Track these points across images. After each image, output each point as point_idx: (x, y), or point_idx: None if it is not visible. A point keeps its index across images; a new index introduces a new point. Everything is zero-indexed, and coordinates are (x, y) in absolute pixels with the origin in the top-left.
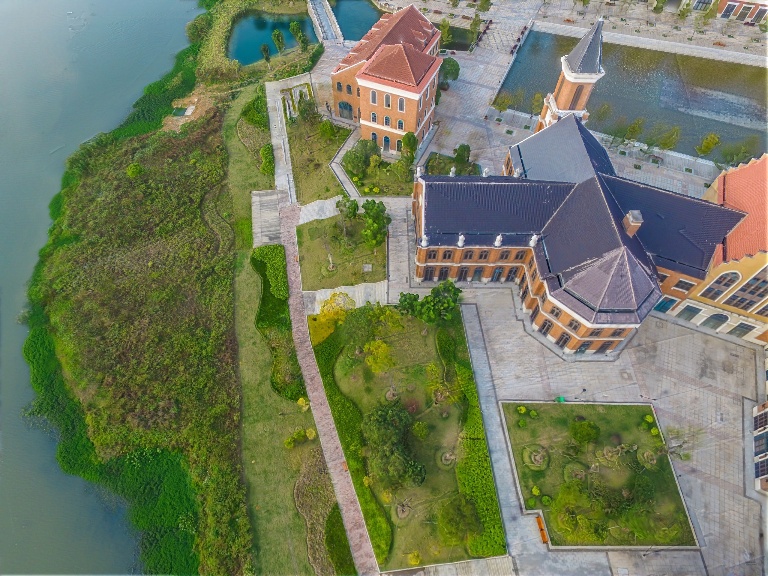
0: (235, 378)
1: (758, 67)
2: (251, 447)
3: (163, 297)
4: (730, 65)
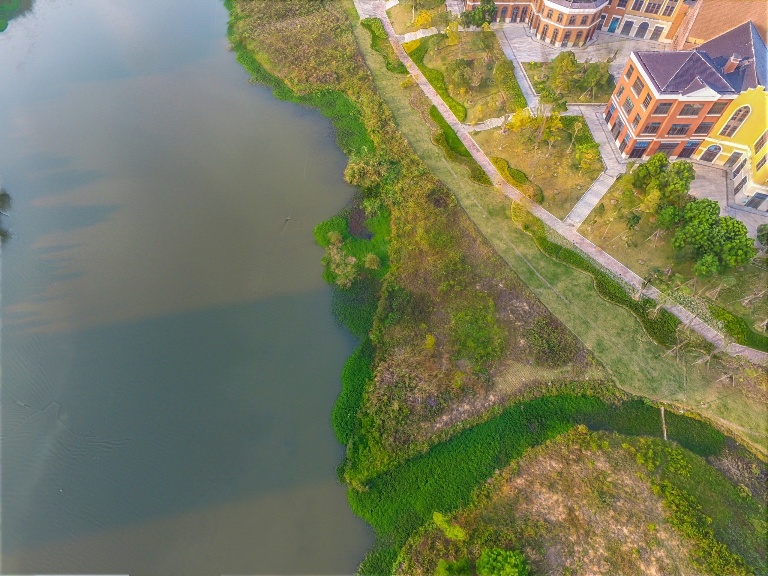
0: (366, 66)
1: None
2: (382, 89)
3: (313, 36)
4: None
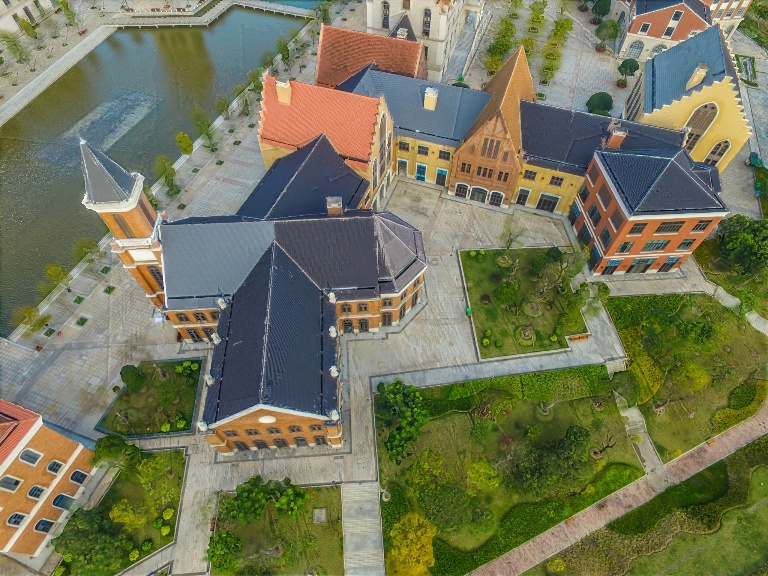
0: None
1: (50, 87)
2: None
3: None
4: (36, 103)
